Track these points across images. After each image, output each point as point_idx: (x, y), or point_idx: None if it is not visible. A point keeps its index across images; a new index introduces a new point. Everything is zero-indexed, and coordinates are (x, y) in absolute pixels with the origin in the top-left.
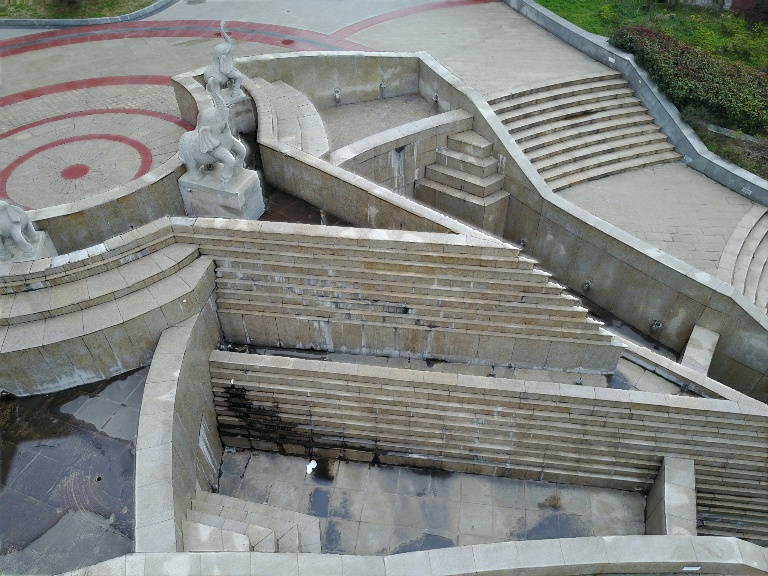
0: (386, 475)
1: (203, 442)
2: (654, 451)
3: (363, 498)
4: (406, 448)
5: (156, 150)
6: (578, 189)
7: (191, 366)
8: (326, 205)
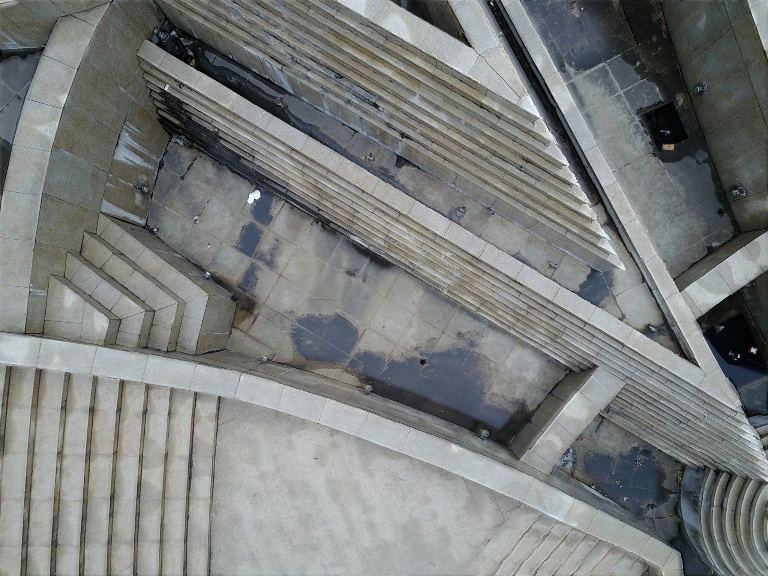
0: (325, 238)
1: (126, 149)
2: (593, 357)
3: (293, 253)
4: (348, 230)
5: None
6: None
7: (97, 75)
8: None
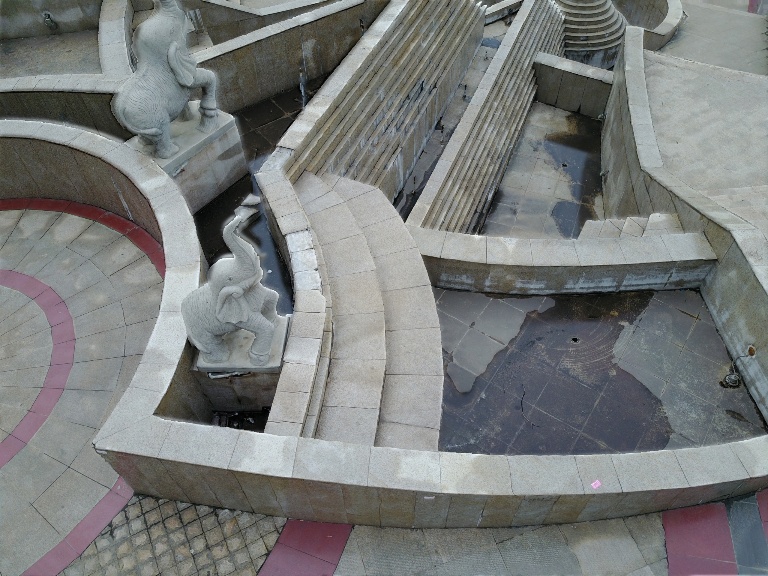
0: (493, 230)
1: None
2: (529, 64)
3: None
4: None
5: None
6: (248, 6)
7: None
8: (246, 97)
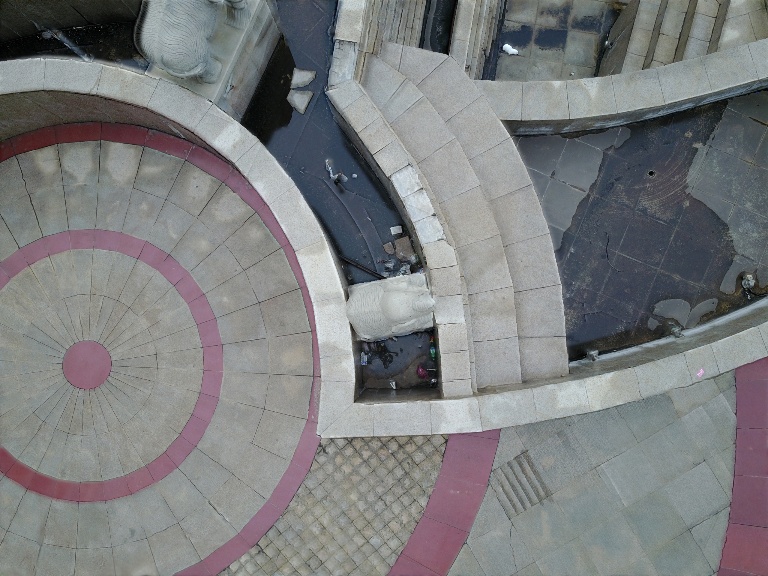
0: None
1: None
2: None
3: None
4: None
5: (22, 234)
6: None
7: None
8: None
